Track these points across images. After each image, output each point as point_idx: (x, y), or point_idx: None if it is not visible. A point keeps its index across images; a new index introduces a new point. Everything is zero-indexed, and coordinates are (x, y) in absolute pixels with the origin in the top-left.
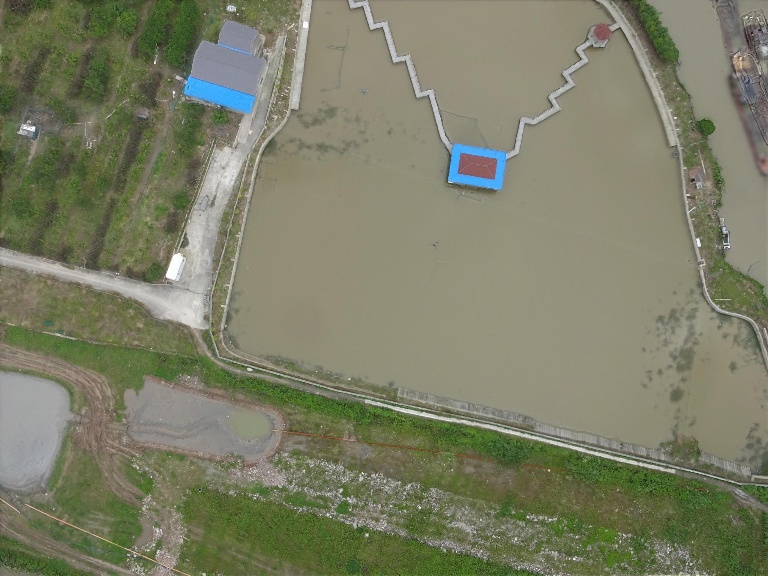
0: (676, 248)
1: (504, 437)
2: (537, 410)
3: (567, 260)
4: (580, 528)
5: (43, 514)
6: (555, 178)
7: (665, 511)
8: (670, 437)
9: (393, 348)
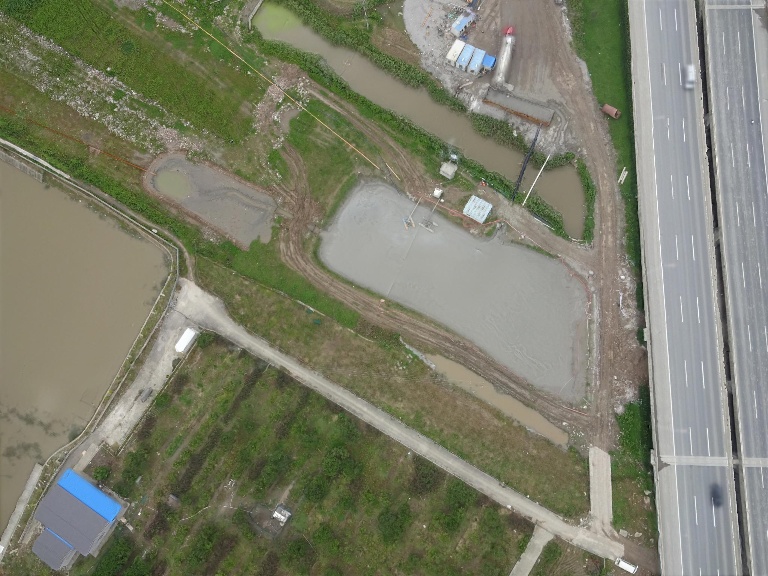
0: None
1: None
2: None
3: None
4: None
5: (367, 157)
6: None
7: None
8: None
9: (34, 217)
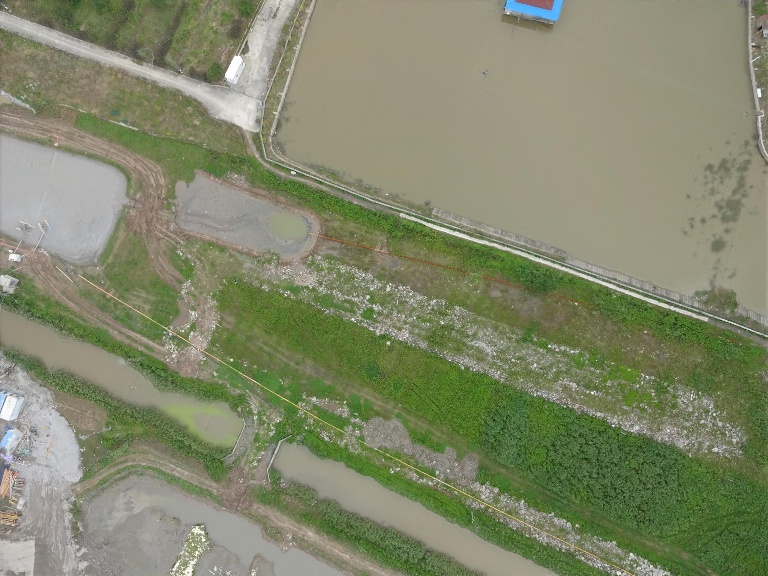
0: (734, 98)
1: (534, 264)
2: (570, 246)
3: (617, 96)
4: (602, 363)
5: (93, 286)
6: (614, 18)
7: (693, 358)
8: (706, 287)
9: (433, 169)
